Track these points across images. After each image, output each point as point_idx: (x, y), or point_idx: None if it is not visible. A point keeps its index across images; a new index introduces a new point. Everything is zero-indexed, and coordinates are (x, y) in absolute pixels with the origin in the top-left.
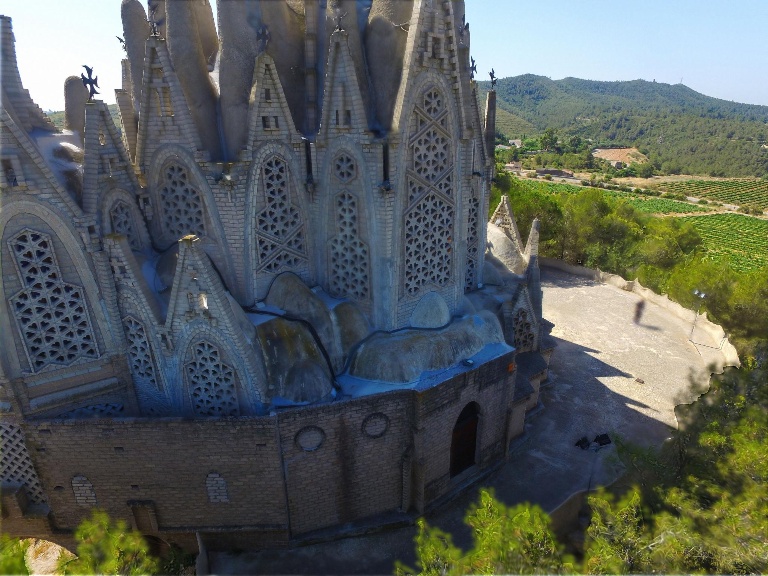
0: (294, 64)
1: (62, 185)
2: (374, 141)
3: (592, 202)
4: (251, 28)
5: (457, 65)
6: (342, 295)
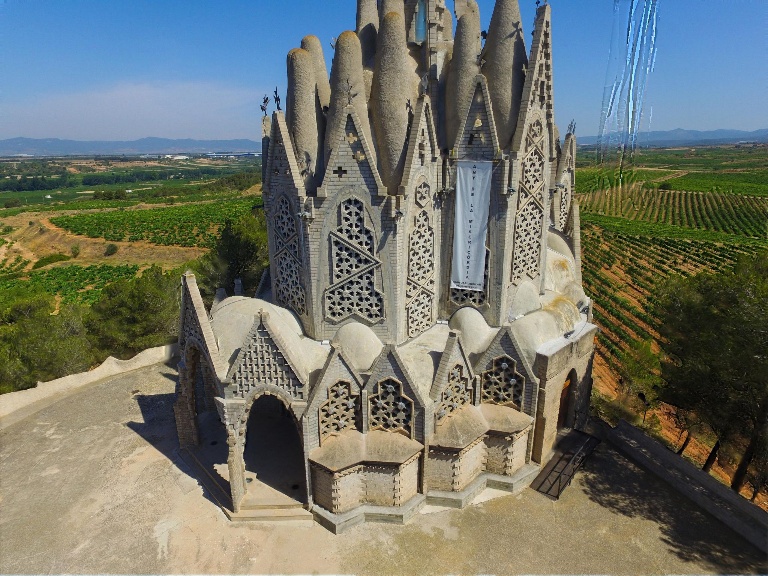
0: None
1: None
2: None
3: None
4: None
5: None
6: None
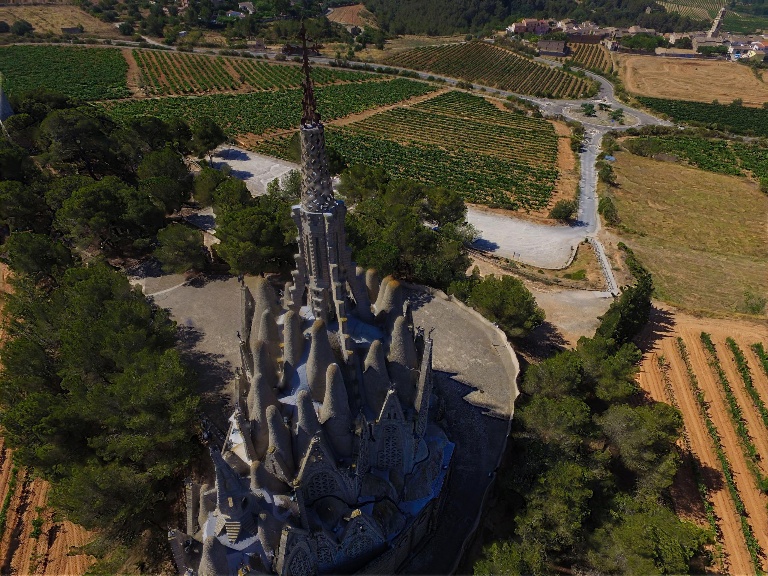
0: (344, 380)
1: None
2: (408, 420)
3: (411, 229)
4: (346, 401)
5: None
6: (386, 468)
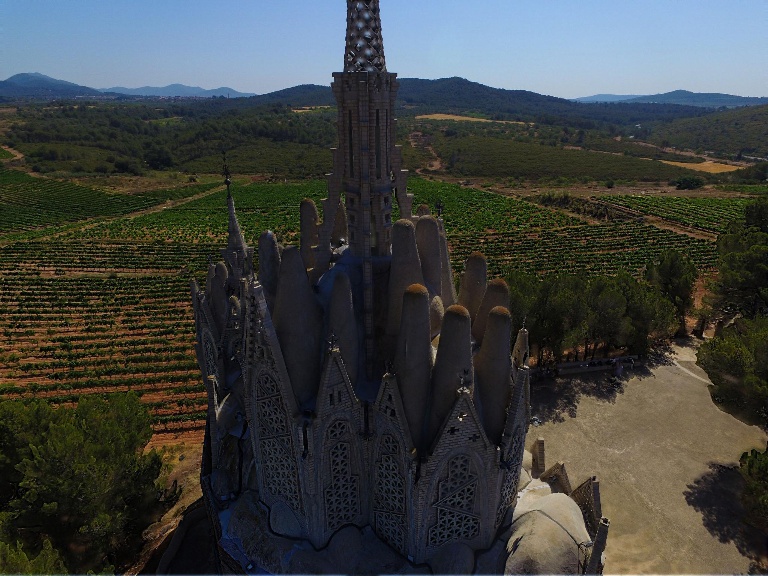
0: None
1: None
2: None
3: None
4: (264, 287)
5: (278, 370)
6: None
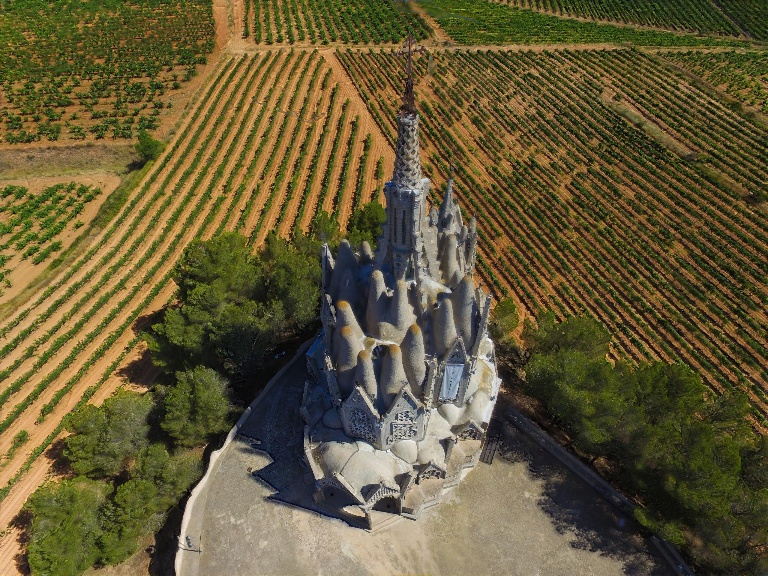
0: None
1: None
2: None
3: None
4: None
5: None
6: None
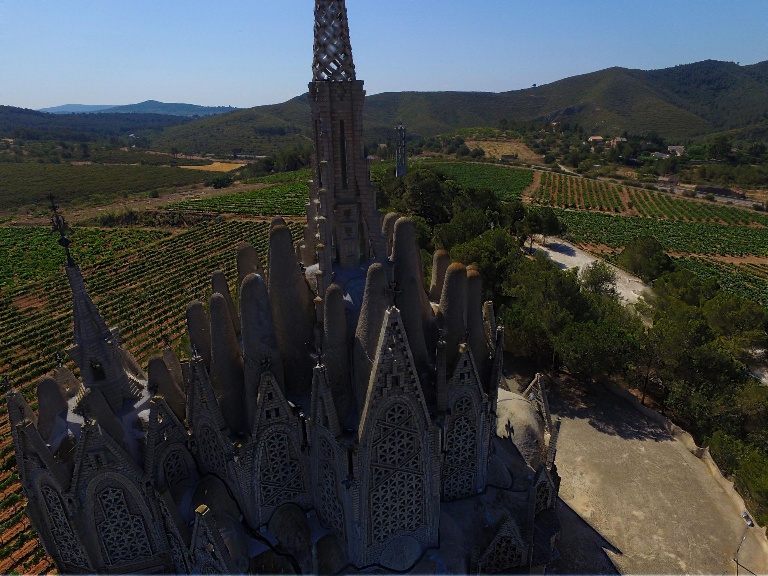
0: (307, 340)
1: (131, 458)
2: (343, 444)
3: (682, 333)
4: (264, 344)
5: (419, 386)
6: (328, 525)
